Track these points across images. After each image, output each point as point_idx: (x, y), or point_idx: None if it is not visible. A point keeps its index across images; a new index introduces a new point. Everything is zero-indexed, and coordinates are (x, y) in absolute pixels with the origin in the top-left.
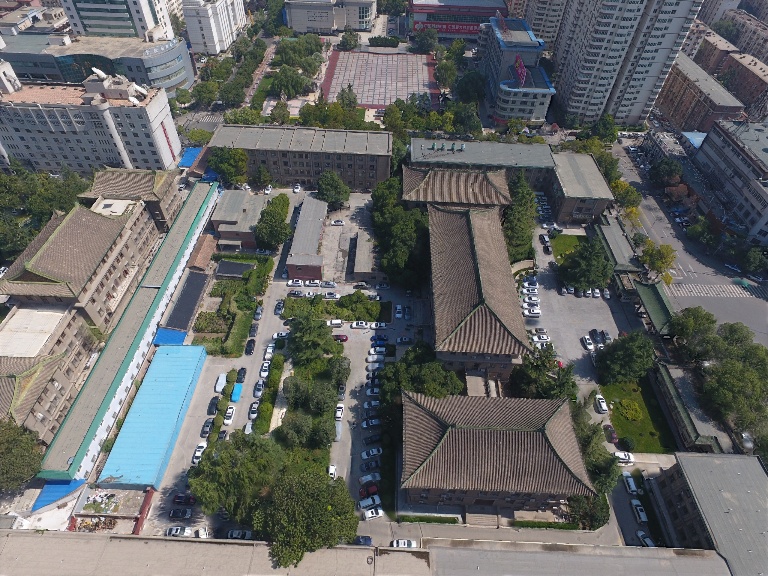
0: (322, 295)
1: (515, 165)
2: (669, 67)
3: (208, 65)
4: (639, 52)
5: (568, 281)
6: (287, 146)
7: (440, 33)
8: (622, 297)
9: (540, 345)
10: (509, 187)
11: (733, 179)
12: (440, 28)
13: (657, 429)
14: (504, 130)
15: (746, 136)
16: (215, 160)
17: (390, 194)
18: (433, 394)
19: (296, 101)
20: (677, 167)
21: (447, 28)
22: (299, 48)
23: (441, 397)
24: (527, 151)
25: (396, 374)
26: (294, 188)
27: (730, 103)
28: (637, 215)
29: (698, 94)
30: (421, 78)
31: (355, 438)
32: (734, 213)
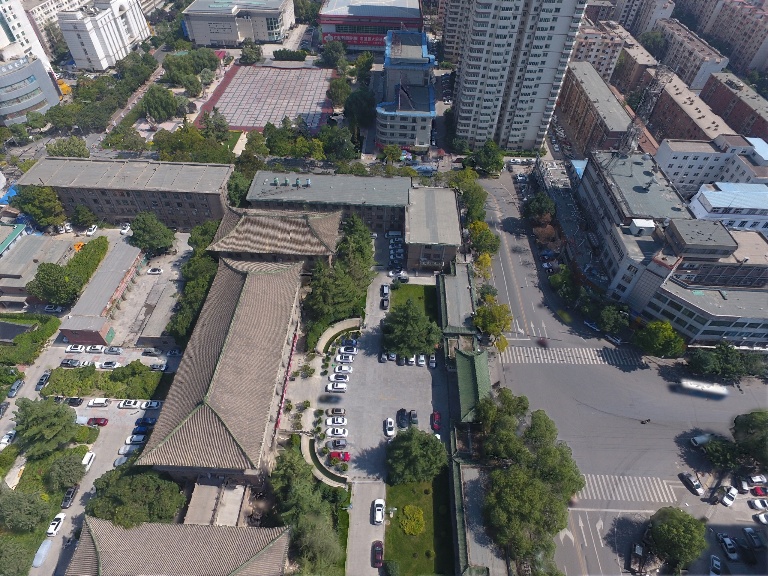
0: (98, 365)
1: (363, 203)
2: (557, 88)
3: (79, 84)
4: (522, 72)
5: (388, 346)
6: (107, 183)
7: (352, 45)
8: (447, 366)
9: (331, 431)
10: (344, 231)
11: (603, 220)
12: (351, 40)
13: (436, 547)
14: (385, 156)
15: (620, 171)
16: (18, 200)
17: (202, 241)
18: (121, 523)
19: (169, 123)
20: (547, 205)
21: (359, 40)
22: (184, 64)
23: (131, 526)
24: (383, 186)
25: (109, 485)
26: (122, 228)
27: (625, 128)
28: (485, 264)
29: (596, 117)
30: (317, 96)
31: (62, 562)
32: (601, 260)
